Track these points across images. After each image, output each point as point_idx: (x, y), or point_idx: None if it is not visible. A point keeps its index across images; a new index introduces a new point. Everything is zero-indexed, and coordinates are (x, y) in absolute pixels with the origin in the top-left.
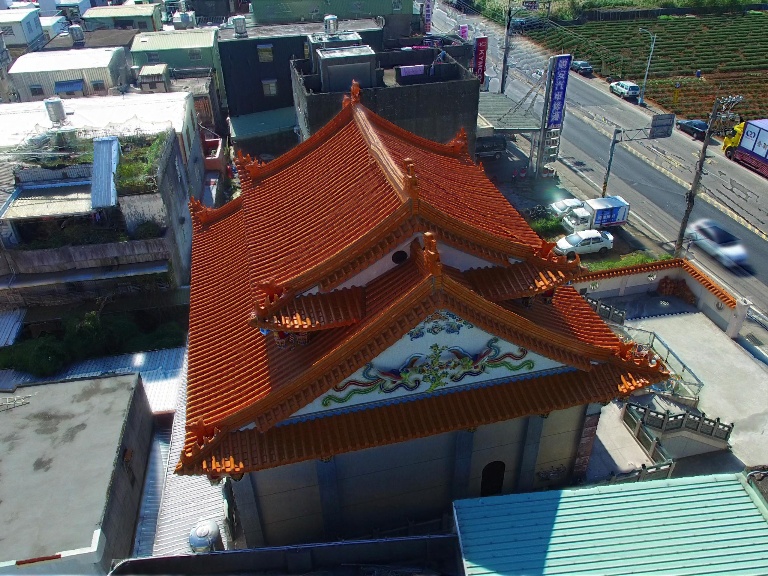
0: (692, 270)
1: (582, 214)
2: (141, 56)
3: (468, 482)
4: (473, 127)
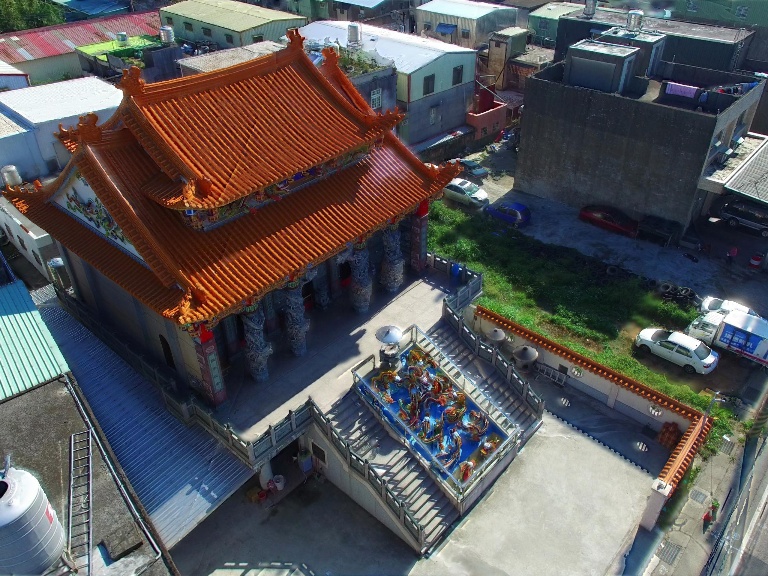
0: (691, 430)
1: (710, 319)
2: (535, 21)
3: (150, 338)
4: (696, 173)
